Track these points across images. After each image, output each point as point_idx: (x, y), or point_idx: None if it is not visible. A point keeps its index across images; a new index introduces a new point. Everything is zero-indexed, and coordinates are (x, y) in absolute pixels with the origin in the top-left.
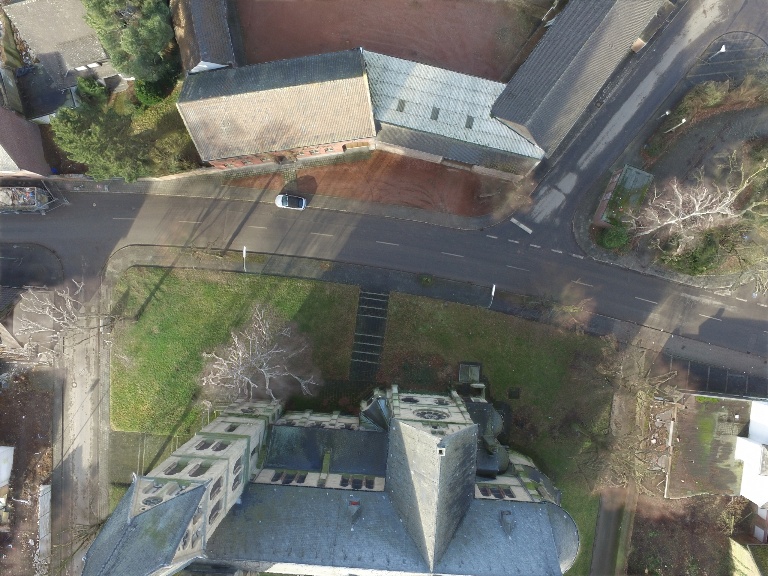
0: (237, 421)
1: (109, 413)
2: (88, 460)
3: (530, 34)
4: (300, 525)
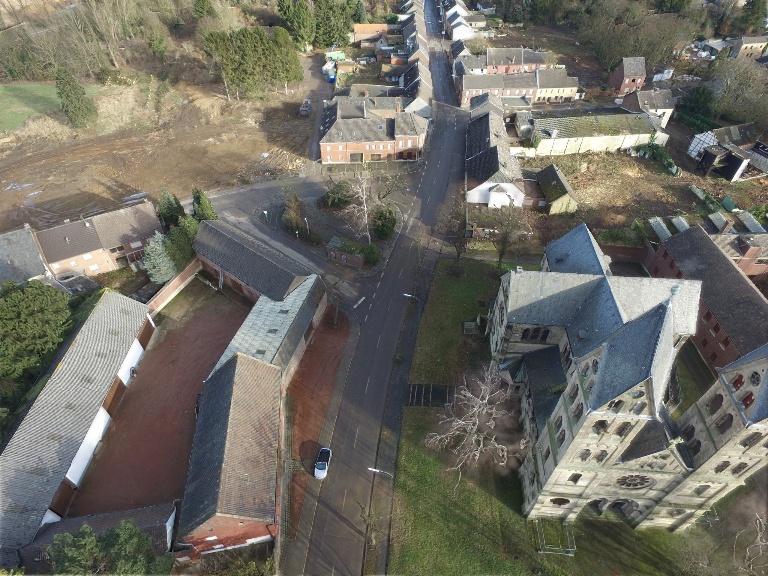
0: (541, 463)
1: None
2: None
3: (224, 296)
4: None
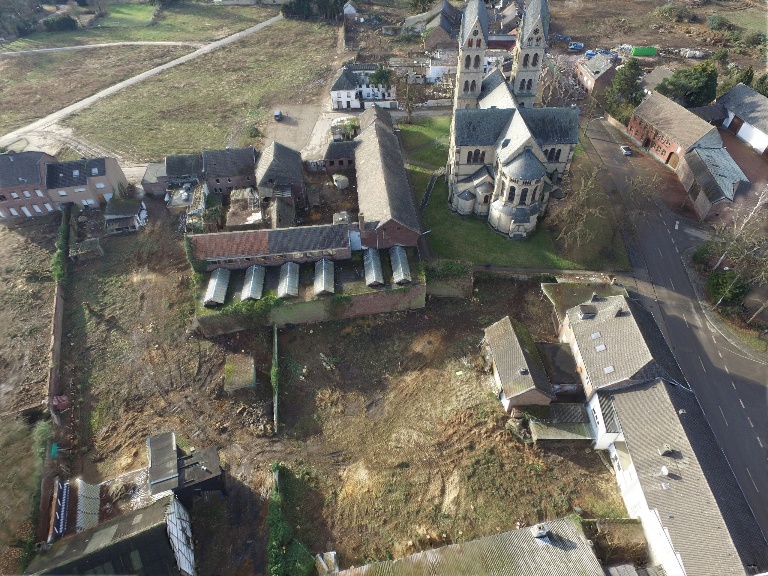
0: None
1: None
2: None
3: None
4: None
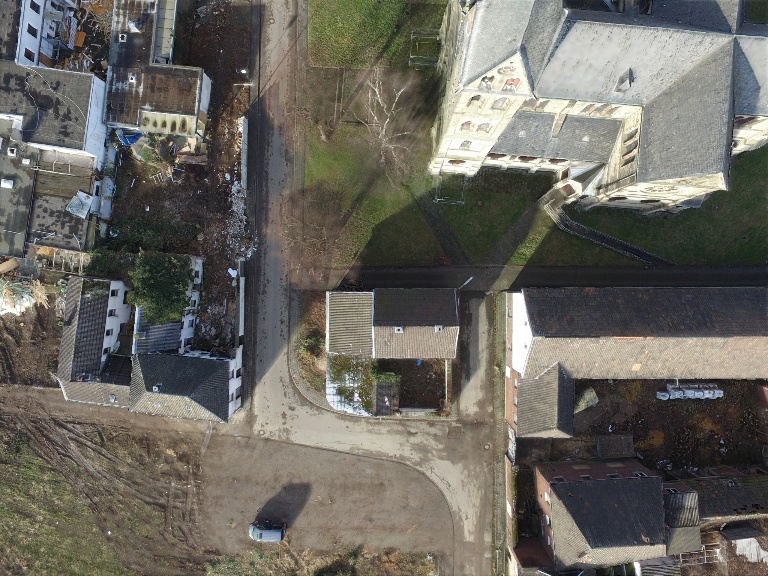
0: None
1: (307, 49)
2: (285, 97)
3: None
4: (582, 15)
